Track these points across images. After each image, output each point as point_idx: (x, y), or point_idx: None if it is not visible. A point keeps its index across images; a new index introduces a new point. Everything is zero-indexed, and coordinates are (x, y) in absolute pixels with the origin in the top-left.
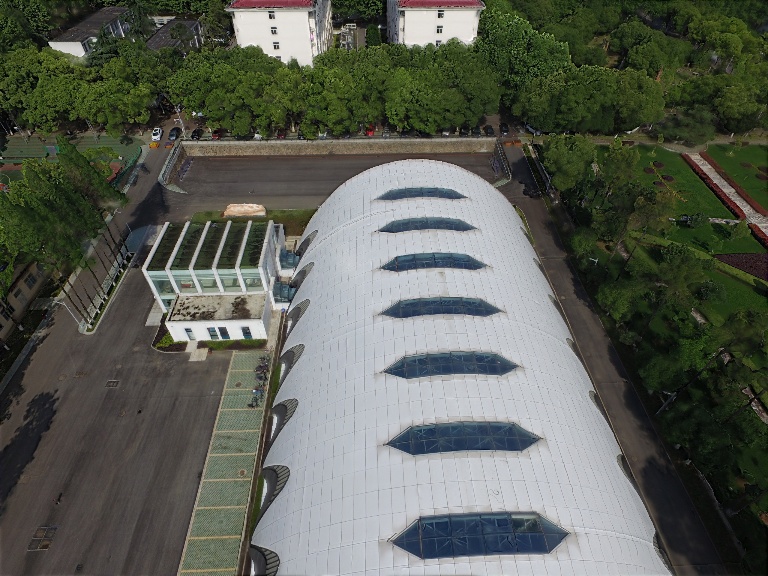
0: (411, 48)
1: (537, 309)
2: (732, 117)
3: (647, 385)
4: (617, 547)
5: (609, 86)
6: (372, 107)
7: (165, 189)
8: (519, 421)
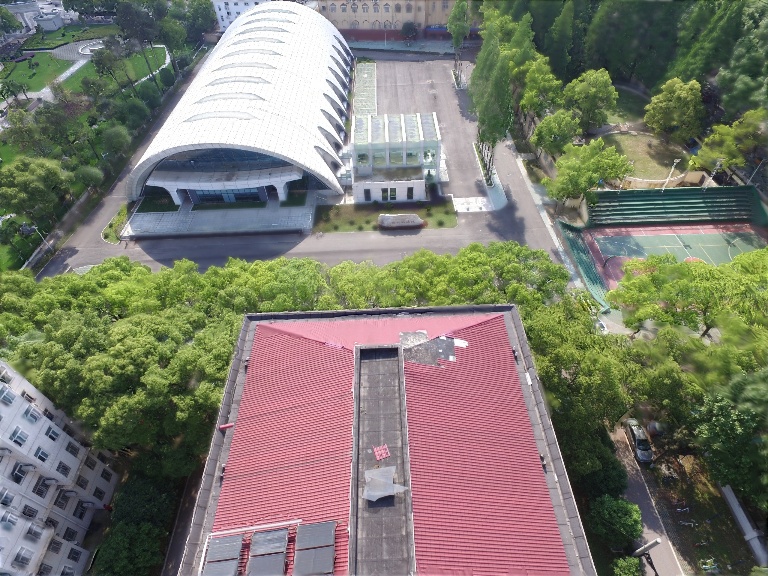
0: (38, 351)
1: None
2: None
3: None
4: None
5: None
6: None
7: None
8: None
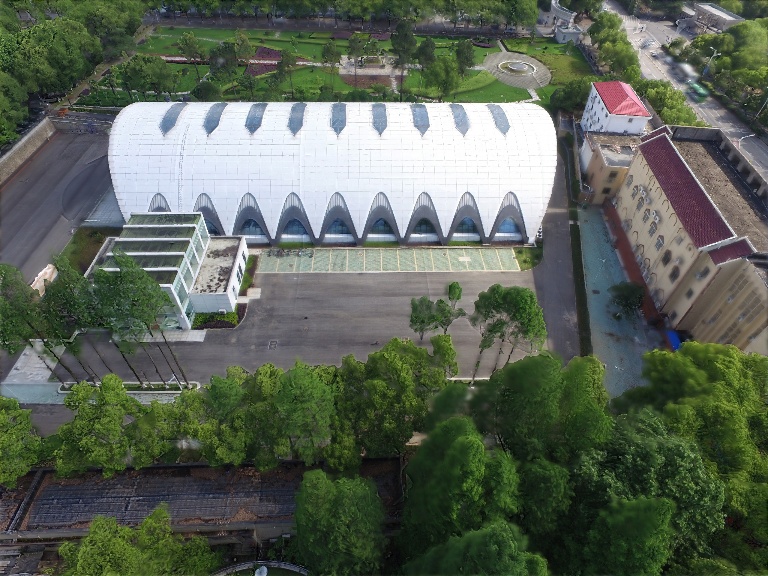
0: None
1: None
2: (124, 27)
3: None
4: None
5: None
6: None
7: None
8: None
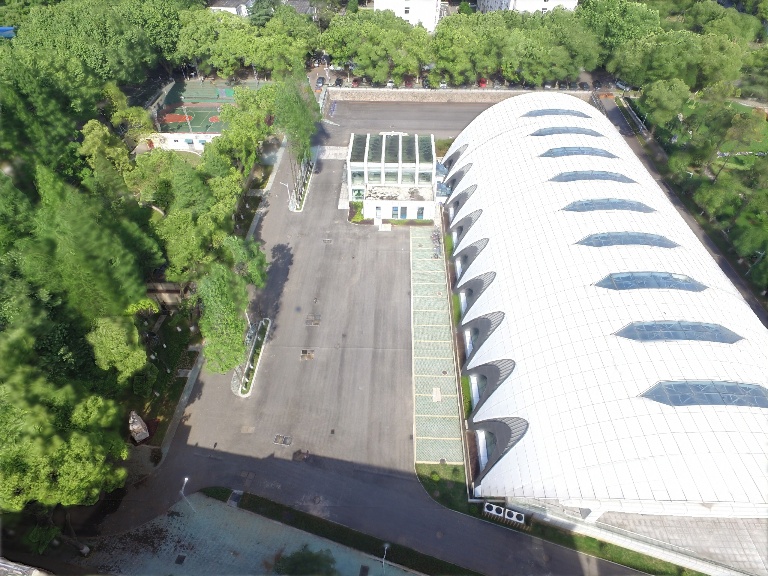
0: (522, 13)
1: (658, 189)
2: None
3: (740, 250)
4: (739, 303)
5: (695, 47)
6: (491, 61)
7: (323, 122)
8: (665, 236)
